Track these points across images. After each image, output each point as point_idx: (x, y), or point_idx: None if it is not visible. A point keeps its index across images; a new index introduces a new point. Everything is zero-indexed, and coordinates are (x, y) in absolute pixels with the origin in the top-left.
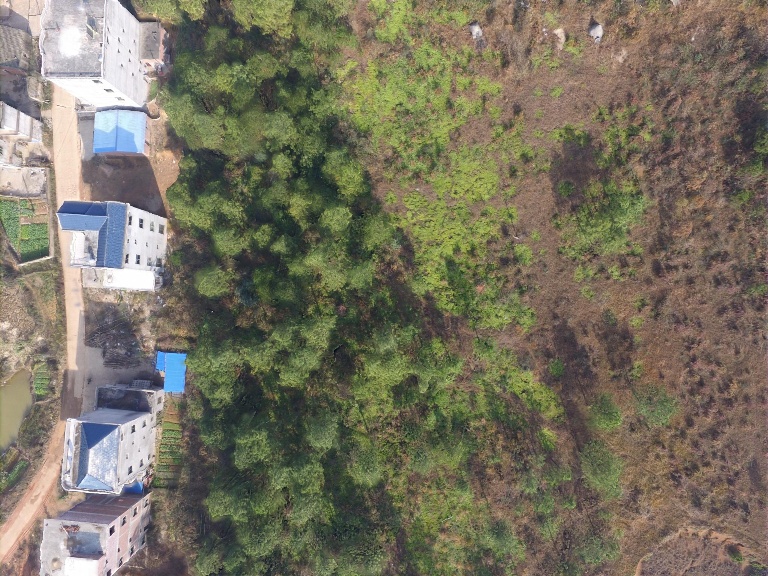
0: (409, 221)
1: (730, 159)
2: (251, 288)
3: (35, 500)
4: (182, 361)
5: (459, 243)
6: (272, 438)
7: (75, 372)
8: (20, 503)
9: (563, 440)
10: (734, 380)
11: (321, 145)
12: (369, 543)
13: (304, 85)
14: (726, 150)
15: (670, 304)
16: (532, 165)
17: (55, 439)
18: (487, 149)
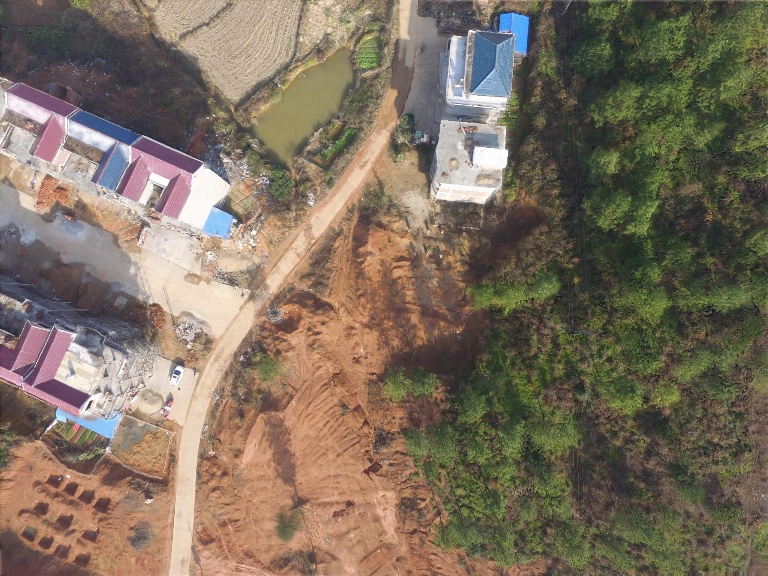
0: None
1: None
2: None
3: (364, 166)
4: (525, 24)
5: None
6: None
7: (407, 42)
8: (348, 168)
9: None
10: None
11: None
12: (749, 163)
13: None
14: None
15: None
16: None
17: (385, 107)
18: None
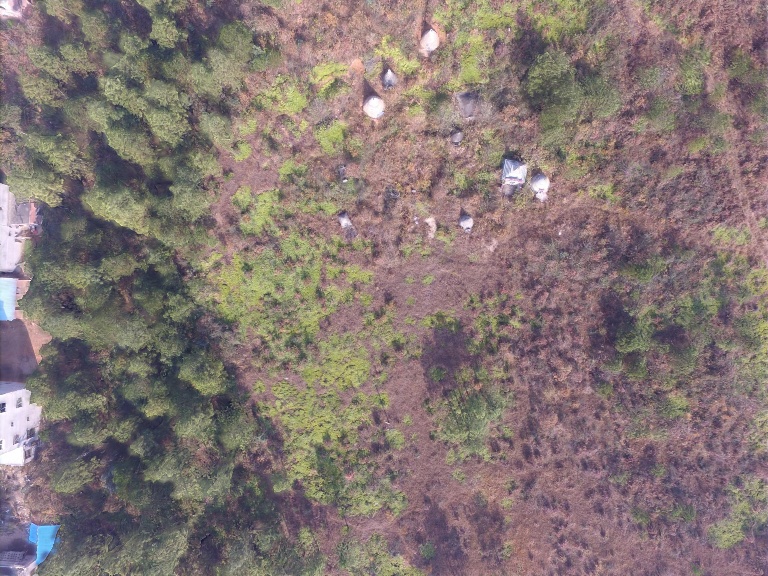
0: (278, 410)
1: (595, 351)
2: None
3: None
4: None
5: (329, 431)
6: None
7: None
8: None
9: None
10: (599, 560)
11: (179, 349)
12: None
13: None
14: (593, 340)
15: (539, 486)
16: (402, 354)
17: None
18: (358, 336)
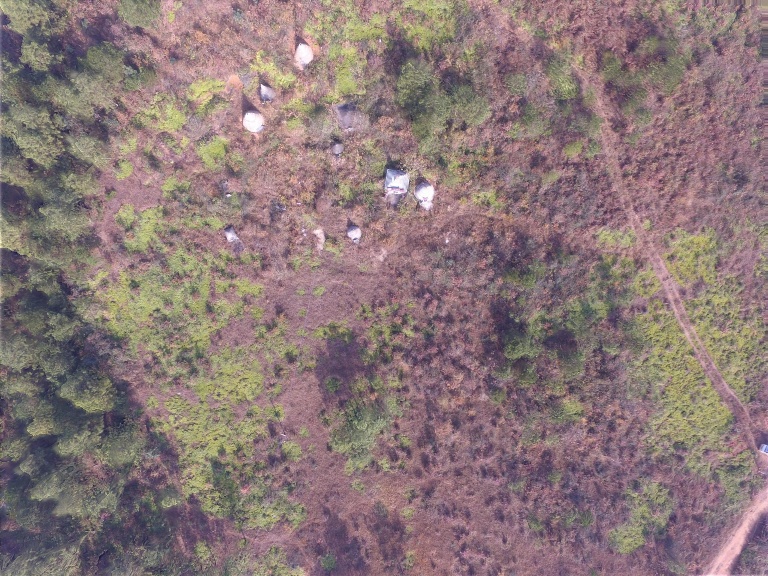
0: (172, 425)
1: (487, 358)
2: None
3: None
4: None
5: (224, 444)
6: None
7: None
8: None
9: None
10: (502, 568)
11: (62, 367)
12: None
13: (47, 303)
14: (486, 347)
15: (439, 495)
16: (294, 366)
17: None
18: (250, 349)
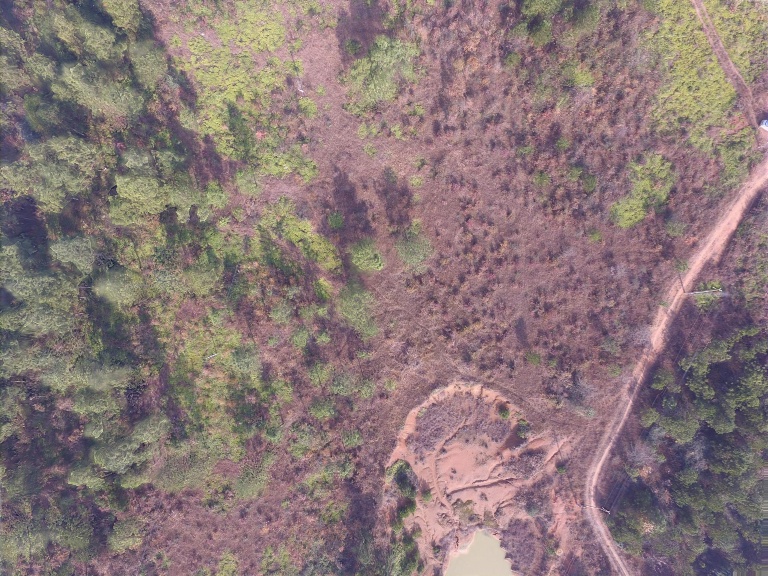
0: (193, 65)
1: (505, 24)
2: (33, 124)
3: None
4: None
5: (242, 91)
6: (22, 255)
7: None
8: None
9: (338, 291)
10: (505, 240)
11: None
12: (133, 377)
13: None
14: (503, 17)
15: (448, 165)
16: (317, 19)
17: None
18: (275, 1)
